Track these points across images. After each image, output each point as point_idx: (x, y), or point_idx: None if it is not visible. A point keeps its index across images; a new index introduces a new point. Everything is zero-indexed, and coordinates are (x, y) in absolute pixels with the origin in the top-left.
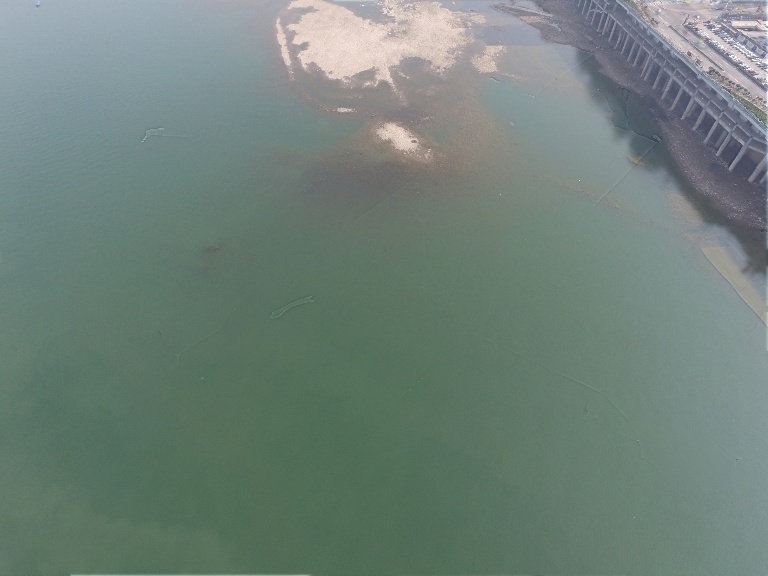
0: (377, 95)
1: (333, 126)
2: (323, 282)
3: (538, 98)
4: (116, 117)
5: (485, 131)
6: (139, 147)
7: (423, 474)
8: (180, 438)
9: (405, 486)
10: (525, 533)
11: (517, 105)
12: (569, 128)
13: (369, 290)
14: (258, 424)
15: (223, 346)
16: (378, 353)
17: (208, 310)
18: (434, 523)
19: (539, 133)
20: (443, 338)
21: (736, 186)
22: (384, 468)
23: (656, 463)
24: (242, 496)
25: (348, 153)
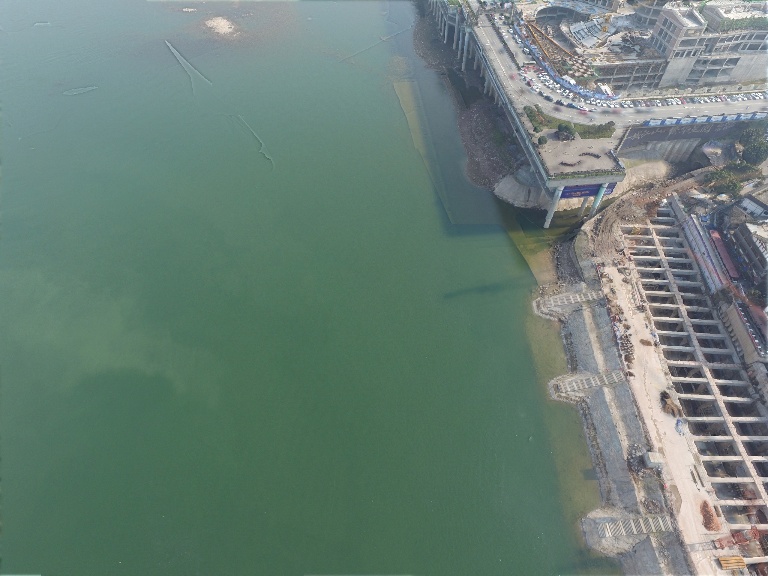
0: (218, 1)
1: (175, 19)
2: (135, 107)
3: (339, 4)
4: (18, 20)
5: (286, 22)
6: (24, 30)
7: (154, 184)
8: (7, 169)
9: (141, 190)
10: (199, 203)
11: (321, 8)
12: (355, 23)
13: (166, 111)
14: (59, 164)
15: (51, 133)
16: (150, 133)
17: (48, 118)
18: (150, 203)
19: (328, 25)
20: (198, 128)
21: (442, 51)
22: (131, 182)
23: (265, 152)
24: (35, 188)
25: (178, 34)
